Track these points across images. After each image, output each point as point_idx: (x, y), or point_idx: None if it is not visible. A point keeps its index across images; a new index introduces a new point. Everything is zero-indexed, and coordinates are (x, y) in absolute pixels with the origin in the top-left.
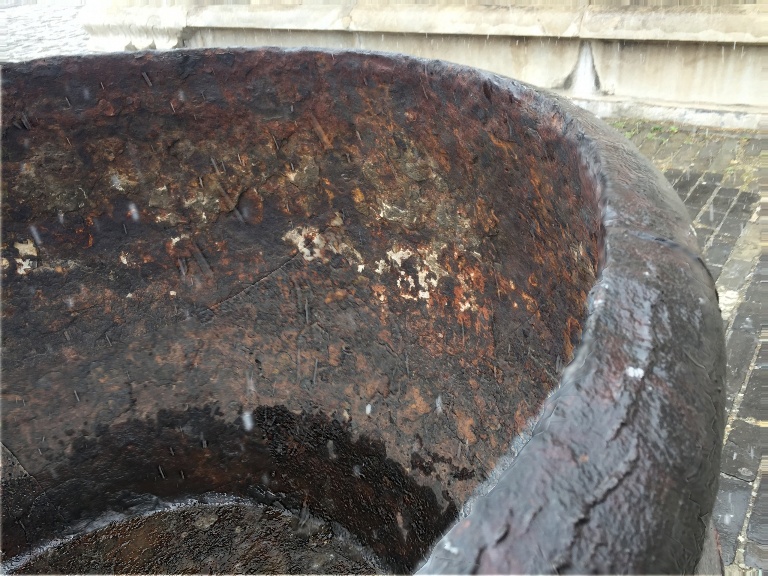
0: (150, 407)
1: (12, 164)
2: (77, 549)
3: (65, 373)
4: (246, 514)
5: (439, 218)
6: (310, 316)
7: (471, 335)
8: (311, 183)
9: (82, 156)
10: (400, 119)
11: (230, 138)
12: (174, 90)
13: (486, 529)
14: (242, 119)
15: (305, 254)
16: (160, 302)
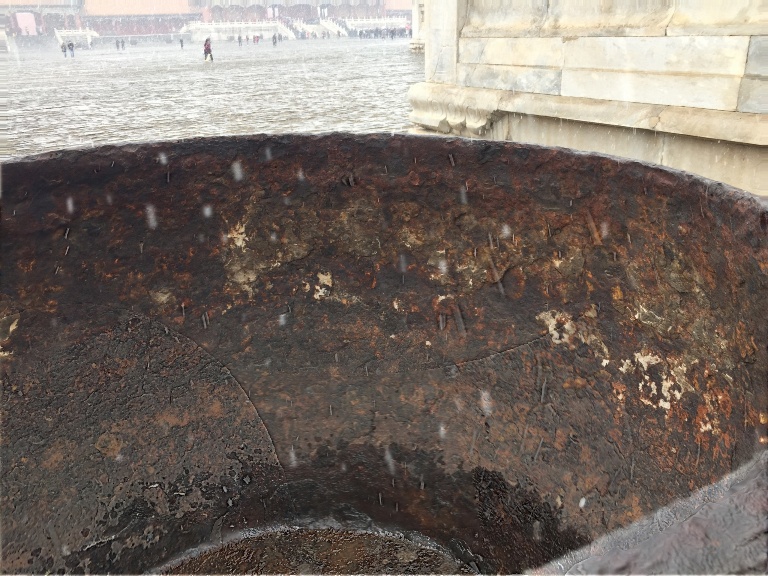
0: (385, 438)
1: (333, 211)
2: (299, 540)
3: (327, 388)
4: (443, 563)
5: (695, 332)
6: (545, 396)
7: (707, 459)
8: (574, 272)
9: (385, 214)
10: (673, 231)
11: (509, 219)
12: (472, 172)
13: (612, 568)
14: (524, 205)
15: (554, 336)
16: (416, 348)
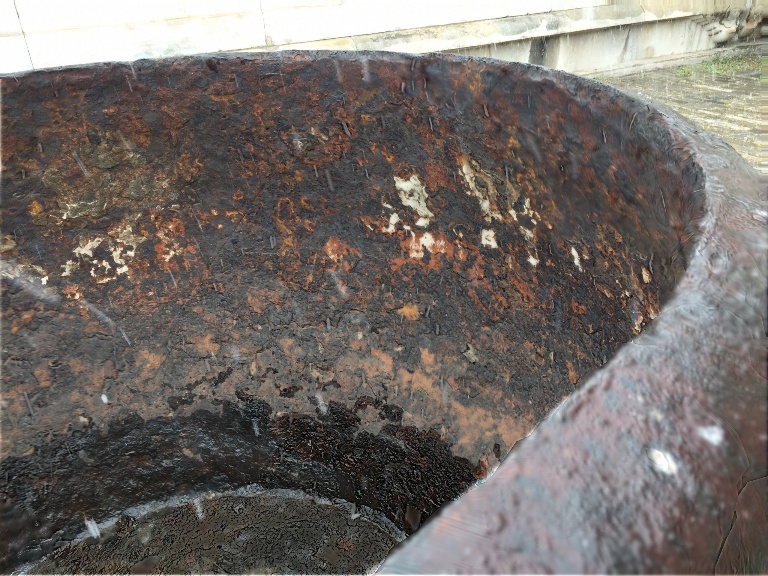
0: None
1: None
2: None
3: None
4: (36, 575)
5: (133, 193)
6: None
7: (181, 275)
8: None
9: None
10: (96, 117)
11: None
12: None
13: None
14: None
15: None
16: None
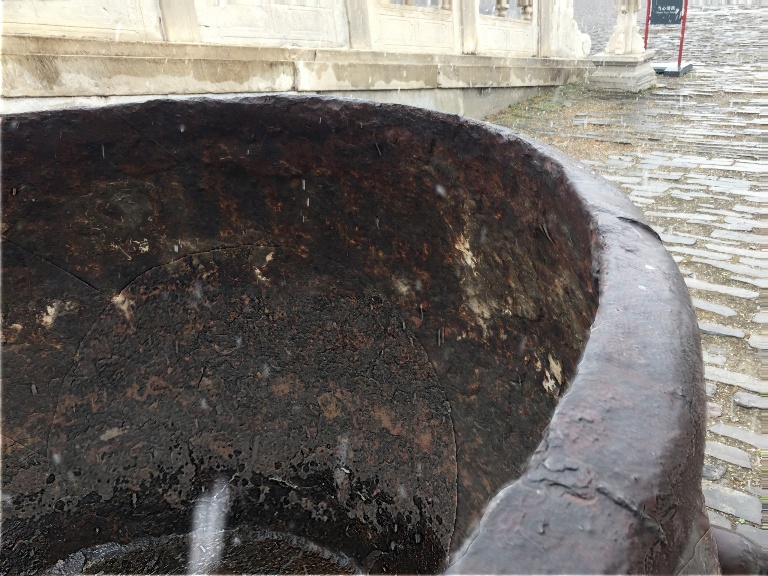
0: None
1: (548, 271)
2: None
3: None
4: None
5: None
6: None
7: None
8: None
9: None
10: None
11: None
12: None
13: None
14: None
15: None
16: None
